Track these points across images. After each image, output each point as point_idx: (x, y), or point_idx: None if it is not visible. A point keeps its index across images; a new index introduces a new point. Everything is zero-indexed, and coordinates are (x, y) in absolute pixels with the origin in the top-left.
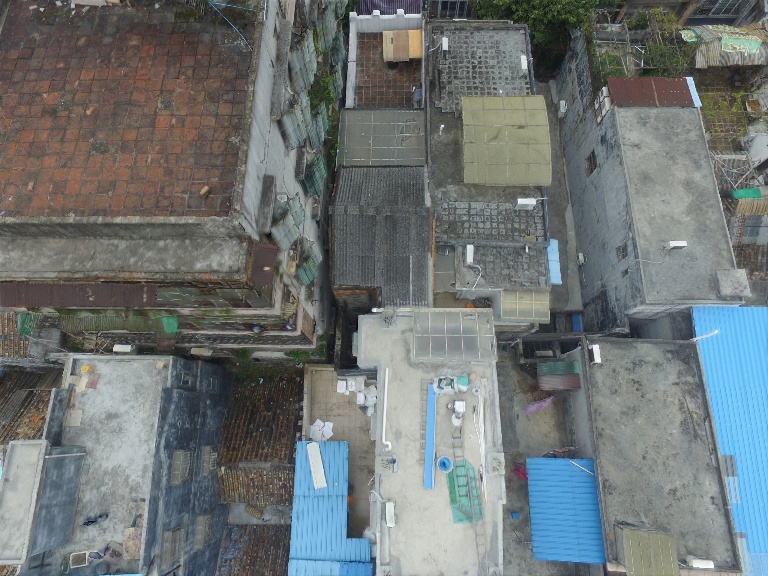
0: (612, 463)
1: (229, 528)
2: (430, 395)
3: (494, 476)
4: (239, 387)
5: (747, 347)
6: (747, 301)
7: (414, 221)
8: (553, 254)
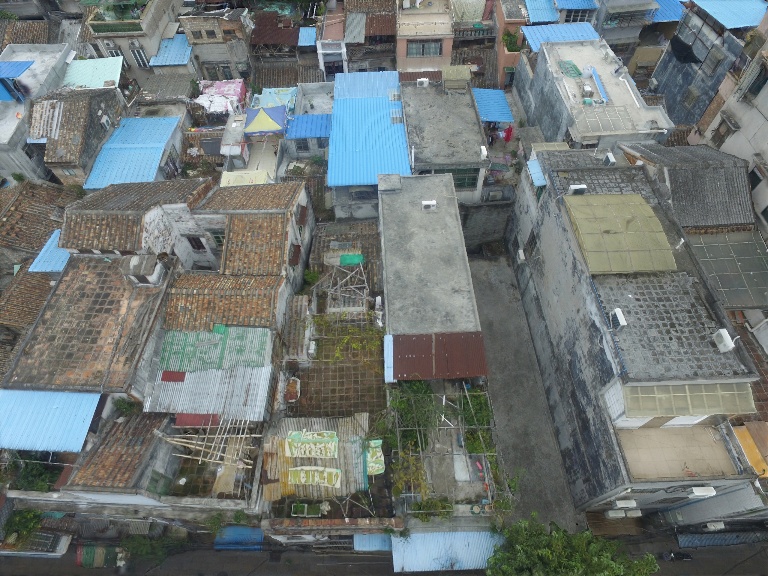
0: (467, 114)
1: None
2: (606, 97)
3: None
4: None
5: (375, 165)
6: None
7: None
8: (538, 177)
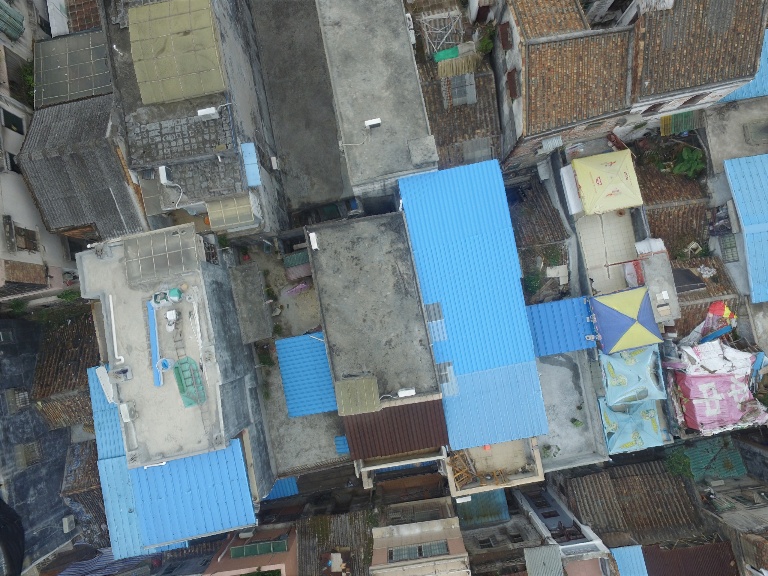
0: (338, 331)
1: (71, 447)
2: (149, 310)
3: (213, 365)
4: (50, 332)
5: (448, 207)
6: (474, 160)
7: (99, 154)
8: (250, 158)
